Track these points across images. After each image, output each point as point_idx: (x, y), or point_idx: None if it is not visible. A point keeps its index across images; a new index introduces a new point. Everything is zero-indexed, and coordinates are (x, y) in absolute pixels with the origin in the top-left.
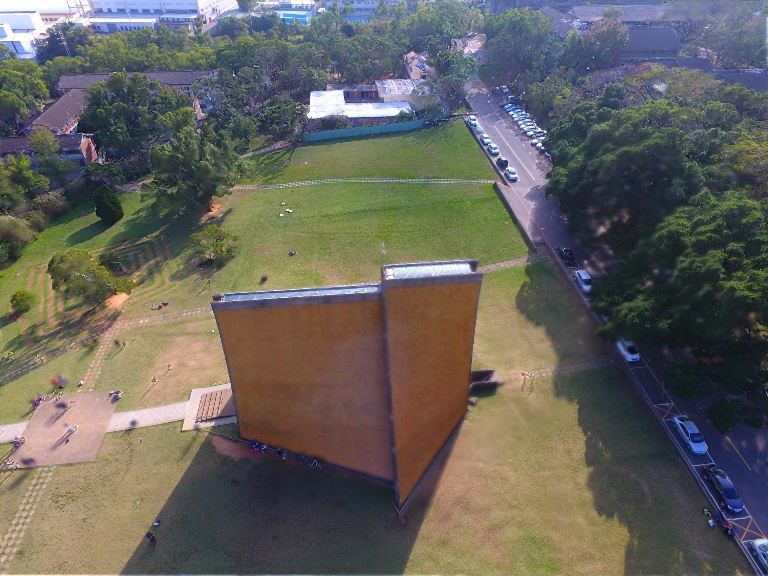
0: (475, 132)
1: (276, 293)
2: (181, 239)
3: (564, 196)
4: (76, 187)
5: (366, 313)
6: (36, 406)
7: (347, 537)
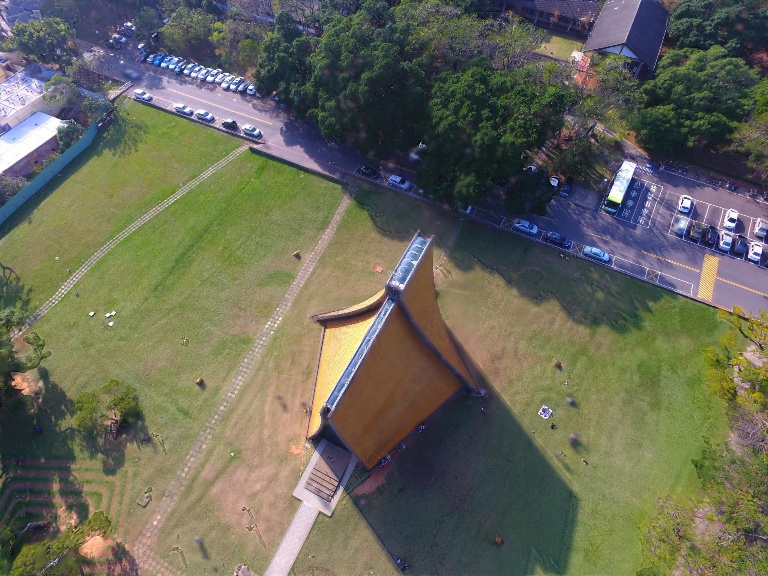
0: (162, 107)
1: (350, 366)
2: (43, 441)
3: None
4: None
5: (393, 320)
6: None
7: (480, 433)
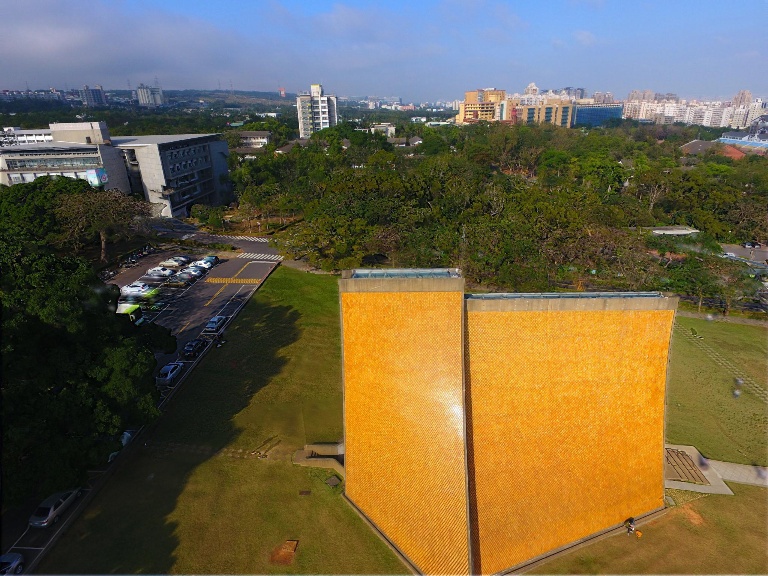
0: None
1: None
2: None
3: None
4: None
5: None
6: None
7: None
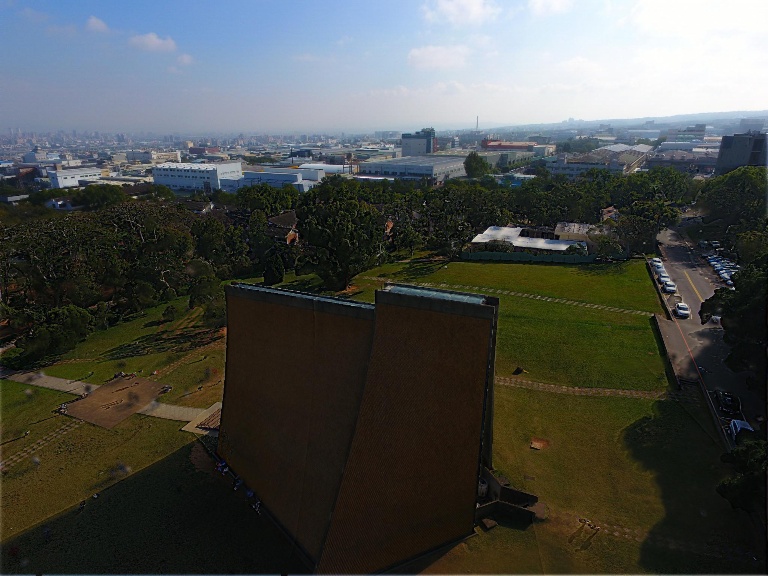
0: (654, 272)
1: (281, 291)
2: None
3: (724, 316)
4: (264, 258)
5: (358, 335)
6: (115, 378)
7: None
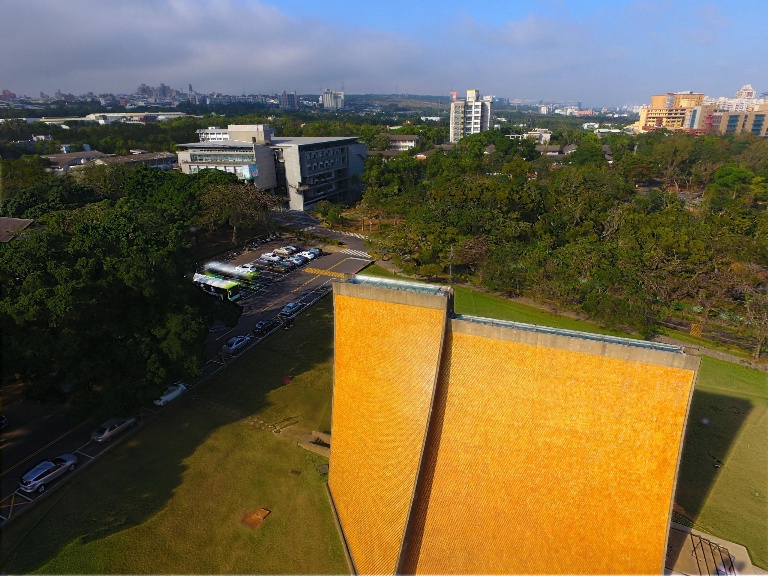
0: None
1: None
2: None
3: None
4: None
5: None
6: None
7: None
